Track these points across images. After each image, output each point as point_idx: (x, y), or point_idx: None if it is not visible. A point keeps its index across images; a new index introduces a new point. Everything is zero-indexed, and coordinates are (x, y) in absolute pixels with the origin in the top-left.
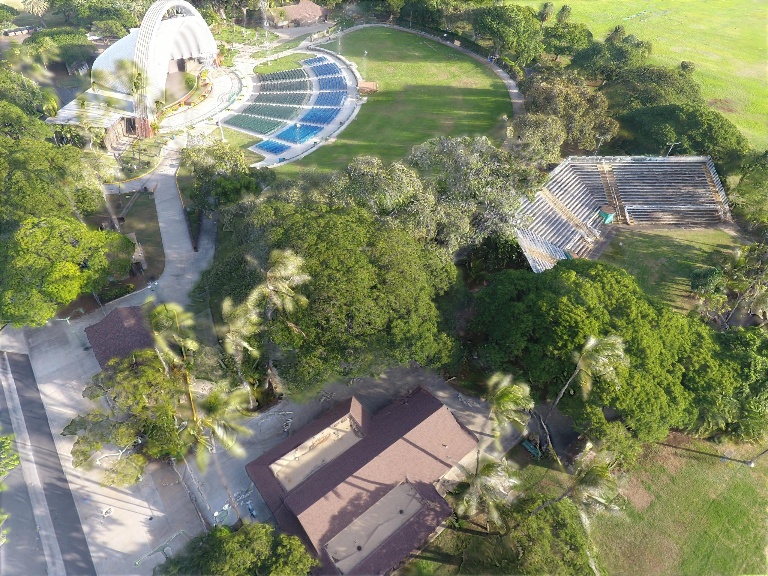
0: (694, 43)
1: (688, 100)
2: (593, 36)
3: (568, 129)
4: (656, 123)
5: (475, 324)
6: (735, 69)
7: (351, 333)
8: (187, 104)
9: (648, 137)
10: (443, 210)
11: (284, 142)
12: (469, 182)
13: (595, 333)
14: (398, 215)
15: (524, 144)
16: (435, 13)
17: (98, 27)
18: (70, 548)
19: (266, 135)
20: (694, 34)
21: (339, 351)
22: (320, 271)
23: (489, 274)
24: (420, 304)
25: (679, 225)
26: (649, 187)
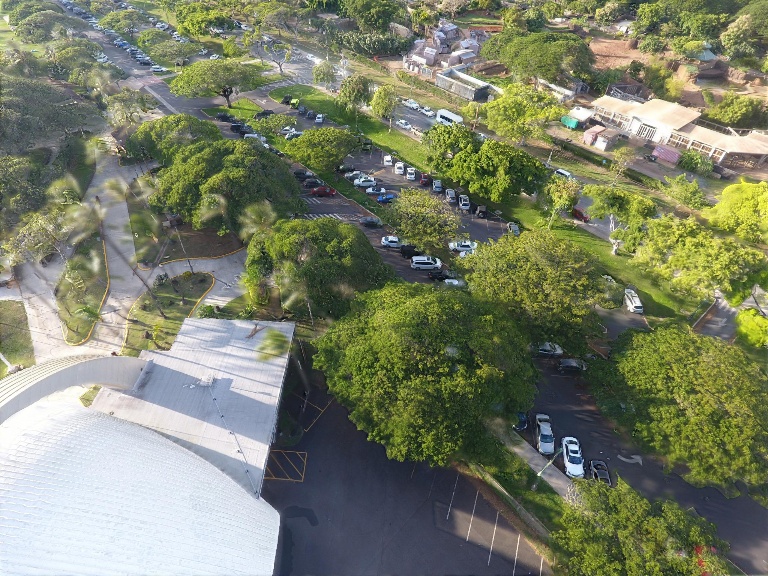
0: None
1: None
2: None
3: None
4: None
5: None
6: None
7: None
8: None
9: None
10: None
11: None
12: None
13: None
14: None
15: None
16: None
17: None
18: (165, 109)
19: None
20: None
21: None
22: None
23: None
24: None
25: None
26: None
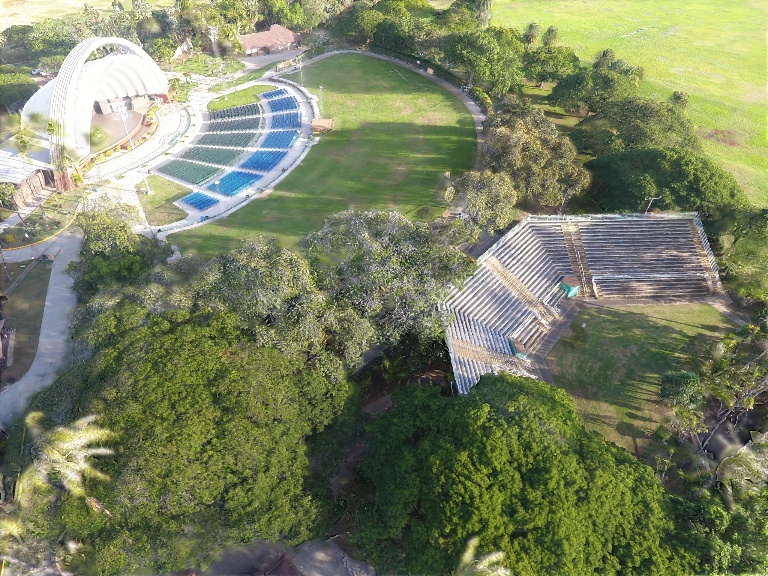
0: (697, 63)
1: (678, 138)
2: (585, 57)
3: (526, 183)
4: (634, 172)
5: (366, 466)
6: (741, 93)
7: (165, 514)
8: (124, 148)
9: (624, 189)
10: (333, 315)
11: (215, 194)
12: (372, 275)
13: (495, 515)
14: (274, 323)
15: (441, 227)
16: (406, 39)
17: (44, 64)
18: None
19: (198, 185)
20: (698, 52)
21: (149, 537)
22: (139, 421)
23: (413, 373)
24: (272, 461)
25: (658, 298)
26: (623, 251)
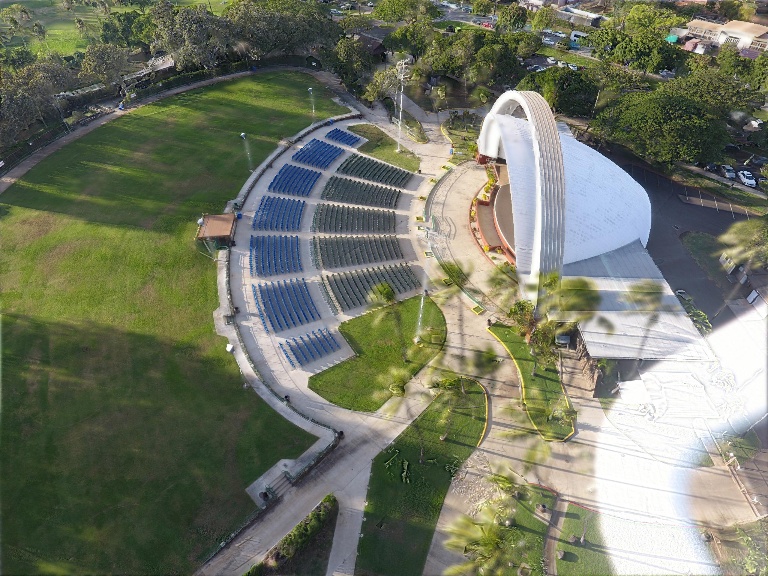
0: None
1: None
2: None
3: None
4: None
5: None
6: None
7: None
8: (484, 204)
9: None
10: None
11: (334, 145)
12: None
13: None
14: None
15: None
16: None
17: None
18: None
19: None
20: None
21: None
22: None
23: None
24: None
25: None
26: None
